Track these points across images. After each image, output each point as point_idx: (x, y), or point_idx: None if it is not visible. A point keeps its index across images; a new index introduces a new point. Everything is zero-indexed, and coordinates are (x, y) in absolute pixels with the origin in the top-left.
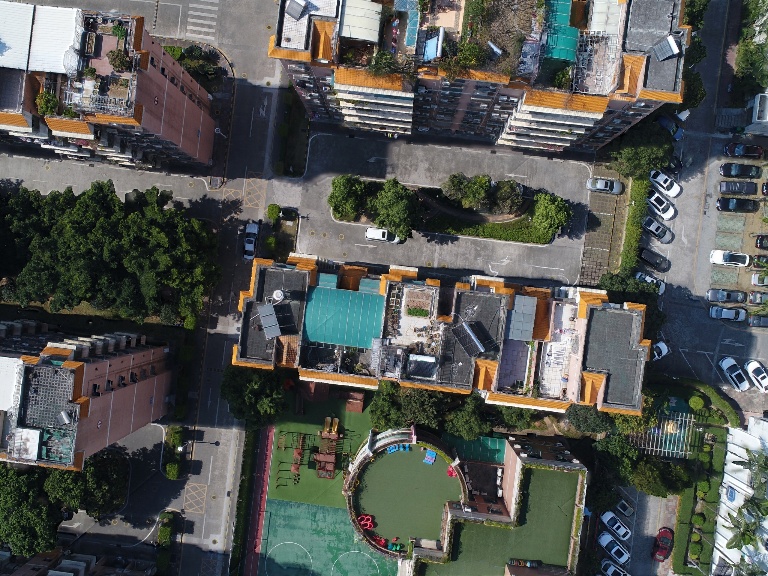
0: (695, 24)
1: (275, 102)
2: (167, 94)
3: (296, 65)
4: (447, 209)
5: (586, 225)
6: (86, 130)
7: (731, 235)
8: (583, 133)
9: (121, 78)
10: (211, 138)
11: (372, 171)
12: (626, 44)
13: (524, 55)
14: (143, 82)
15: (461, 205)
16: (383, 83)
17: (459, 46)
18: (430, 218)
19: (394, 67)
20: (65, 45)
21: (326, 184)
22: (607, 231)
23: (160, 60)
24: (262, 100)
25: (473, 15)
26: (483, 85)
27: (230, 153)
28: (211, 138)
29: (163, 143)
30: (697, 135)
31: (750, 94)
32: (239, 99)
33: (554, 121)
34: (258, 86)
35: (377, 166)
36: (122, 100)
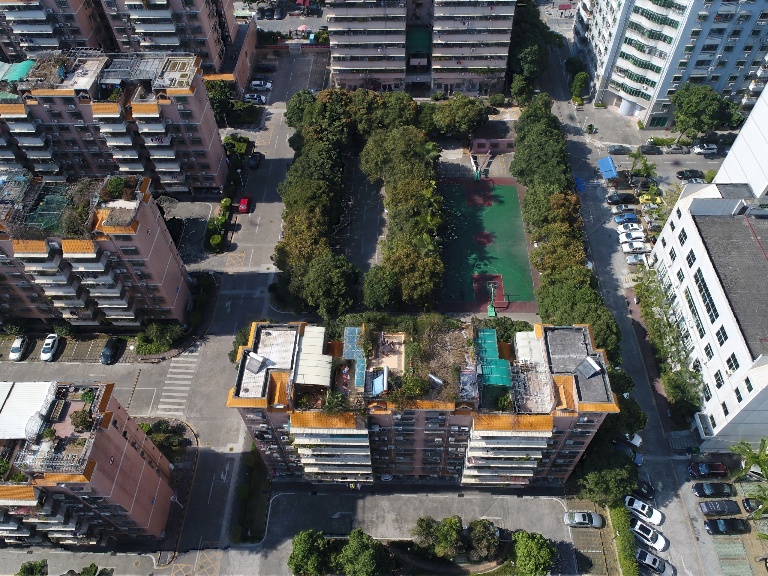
0: (615, 360)
1: (237, 466)
2: (125, 456)
3: (254, 415)
4: (421, 563)
5: (577, 566)
6: (31, 495)
7: (736, 562)
8: (541, 457)
9: (80, 438)
10: (167, 508)
11: (337, 528)
12: (553, 368)
13: (464, 384)
14: (101, 441)
15: (436, 557)
16: (337, 422)
17: (403, 380)
18: (404, 575)
19: (346, 405)
20: (32, 413)
21: (287, 548)
22: (601, 571)
23: (124, 425)
24: (224, 466)
25: (413, 356)
26: (432, 416)
27: (185, 523)
28: (167, 508)
29: (112, 508)
30: (657, 459)
31: (690, 416)
32: (201, 467)
33: (508, 446)
34: (221, 453)
35: (342, 522)
36: (75, 456)
